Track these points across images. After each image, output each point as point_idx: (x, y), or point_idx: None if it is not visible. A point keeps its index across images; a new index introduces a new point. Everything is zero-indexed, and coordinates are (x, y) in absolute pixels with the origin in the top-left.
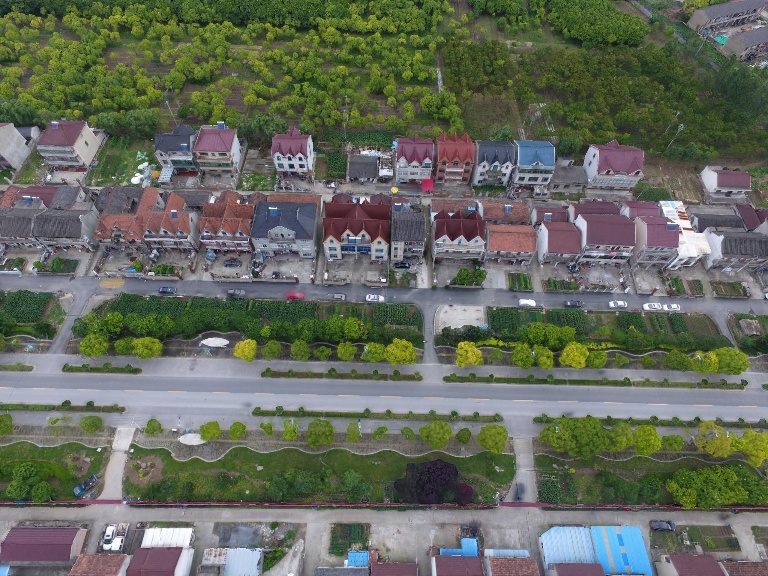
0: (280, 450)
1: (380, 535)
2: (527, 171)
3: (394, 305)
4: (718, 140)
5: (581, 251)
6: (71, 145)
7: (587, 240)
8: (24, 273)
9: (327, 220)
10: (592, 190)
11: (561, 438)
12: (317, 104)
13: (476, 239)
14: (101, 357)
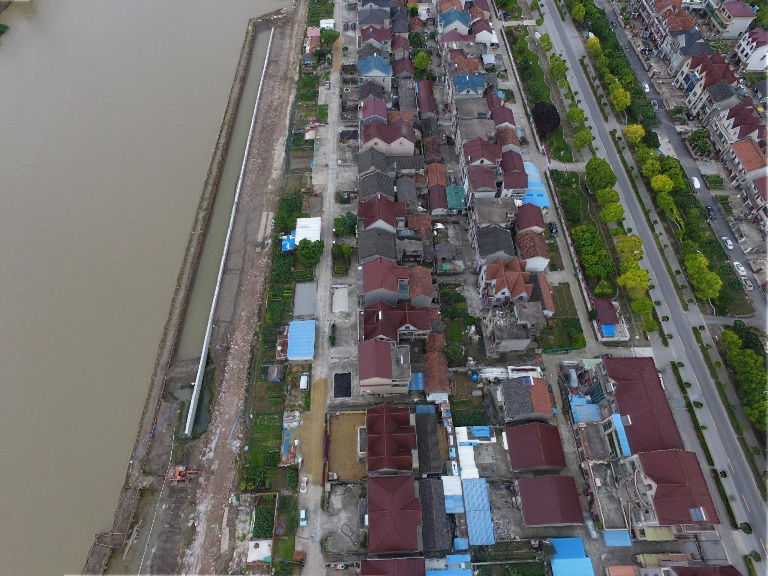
0: (542, 69)
1: (511, 107)
2: None
3: None
4: None
5: None
6: None
7: None
8: None
9: (703, 54)
10: None
11: None
12: None
13: None
14: (566, 9)
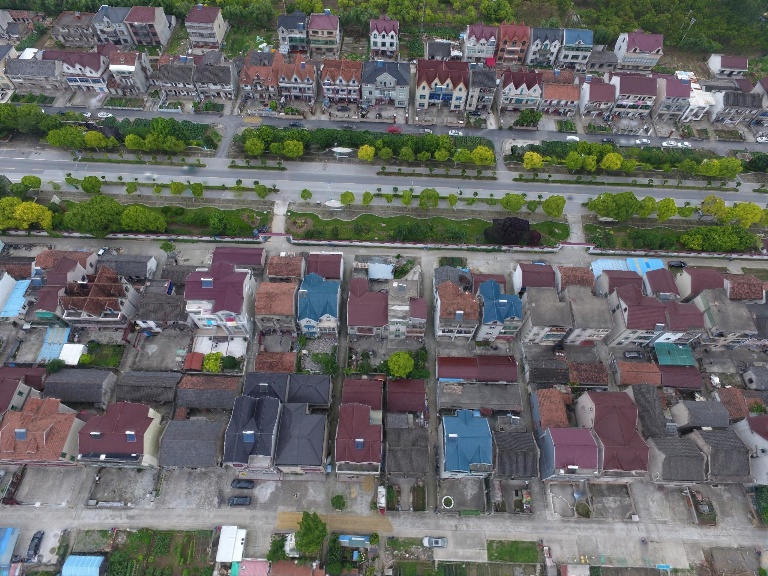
0: (397, 216)
1: (474, 265)
2: (571, 49)
3: (471, 136)
4: (722, 36)
5: (615, 101)
6: (212, 22)
7: (620, 91)
8: (184, 112)
9: (421, 71)
10: (621, 70)
11: (605, 202)
12: (397, 6)
13: (535, 88)
14: (255, 161)
